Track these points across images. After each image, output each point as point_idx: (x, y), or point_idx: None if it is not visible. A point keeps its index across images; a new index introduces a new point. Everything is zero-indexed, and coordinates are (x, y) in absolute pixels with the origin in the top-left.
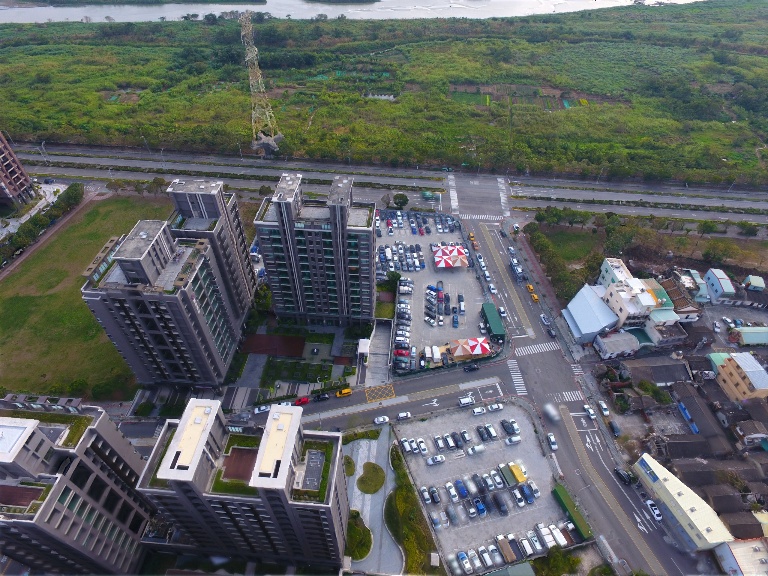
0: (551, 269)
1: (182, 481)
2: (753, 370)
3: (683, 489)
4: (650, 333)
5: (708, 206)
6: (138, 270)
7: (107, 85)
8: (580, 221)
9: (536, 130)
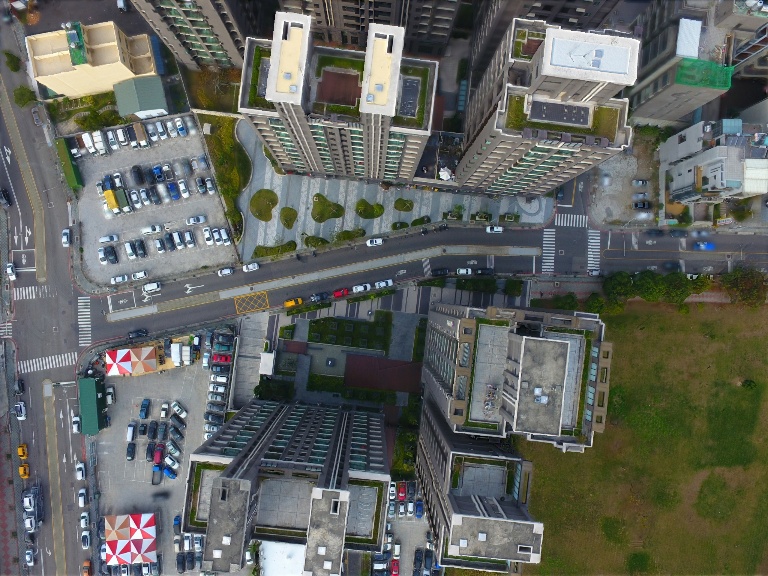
0: None
1: None
2: None
3: None
4: None
5: None
6: None
7: None
8: None
9: None
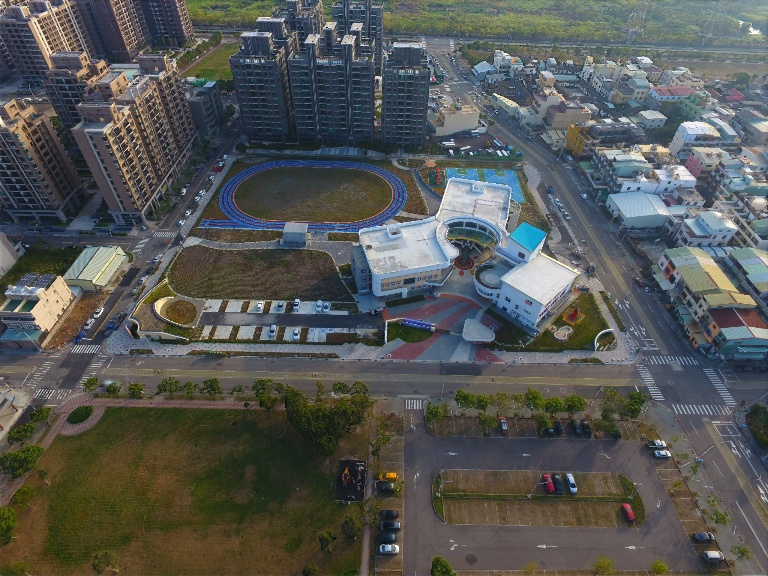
0: (469, 57)
1: (328, 36)
2: (547, 74)
3: (506, 99)
4: (511, 74)
5: (563, 47)
6: (294, 8)
7: (204, 5)
8: (491, 51)
9: (478, 24)
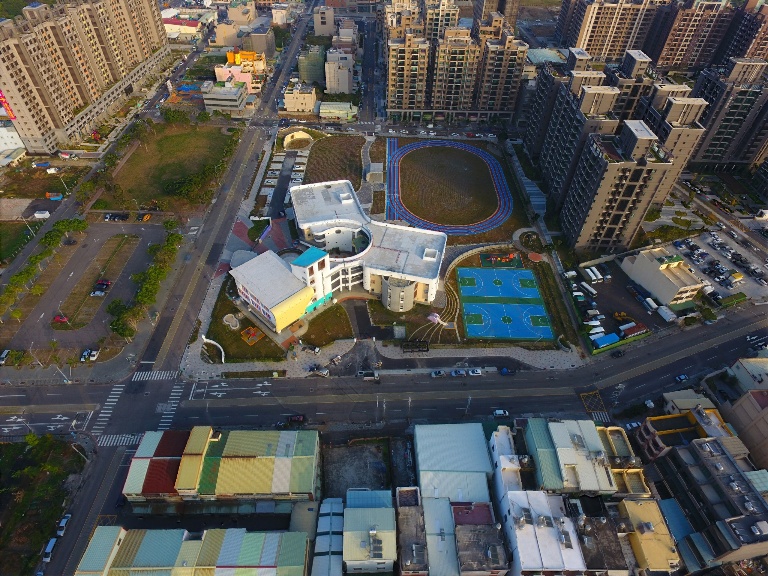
0: None
1: None
2: None
3: None
4: None
5: None
6: None
7: None
8: None
9: None
